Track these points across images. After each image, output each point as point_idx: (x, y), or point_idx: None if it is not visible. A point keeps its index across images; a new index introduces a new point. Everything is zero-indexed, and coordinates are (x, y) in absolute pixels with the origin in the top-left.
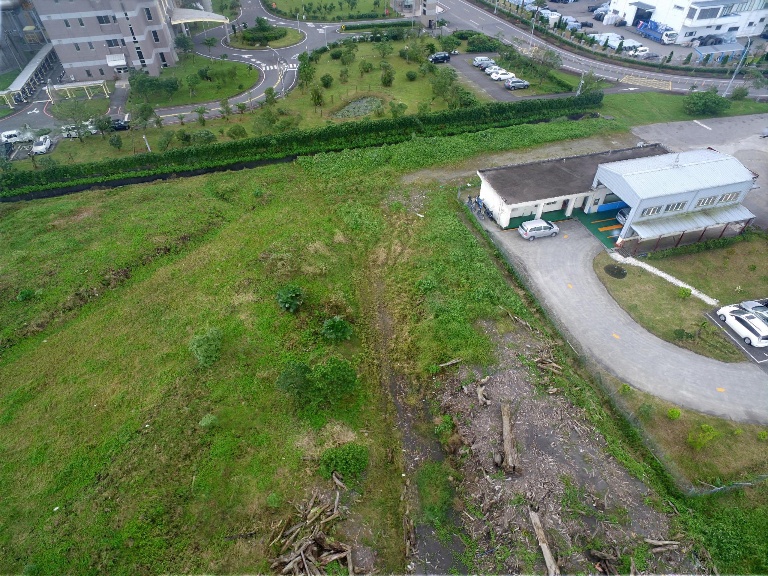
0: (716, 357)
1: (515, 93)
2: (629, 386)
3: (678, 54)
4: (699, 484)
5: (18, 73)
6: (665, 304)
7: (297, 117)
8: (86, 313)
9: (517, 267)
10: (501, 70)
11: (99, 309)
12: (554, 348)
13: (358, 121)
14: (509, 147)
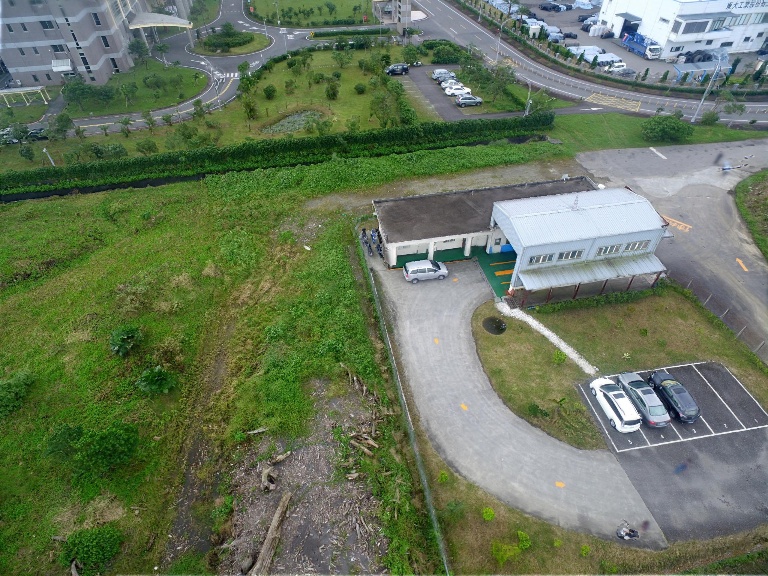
0: (570, 441)
1: (465, 110)
2: (453, 473)
3: (659, 71)
4: None
5: None
6: (535, 370)
7: (217, 132)
8: None
9: (387, 314)
10: (457, 85)
11: None
12: (384, 419)
13: (277, 139)
14: (433, 172)
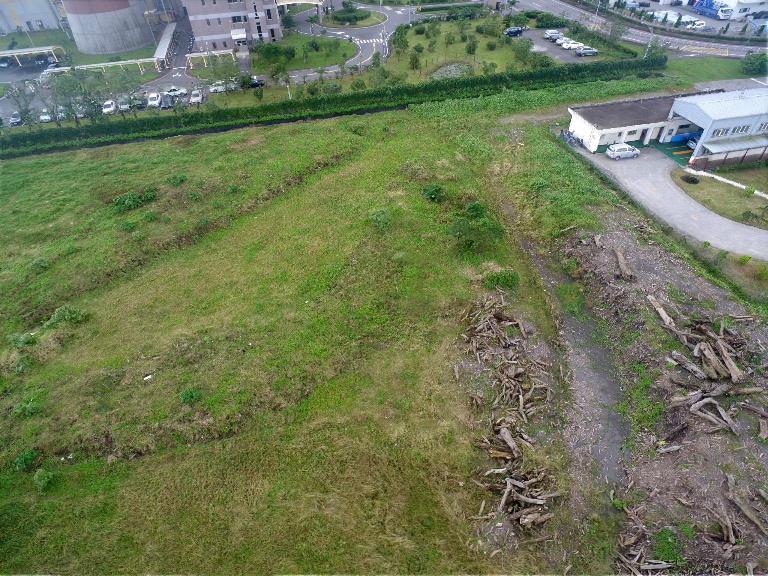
0: None
1: (586, 59)
2: None
3: (733, 27)
4: (766, 298)
5: (151, 47)
6: (733, 200)
7: (404, 75)
8: (279, 202)
9: (608, 177)
10: (571, 41)
11: (287, 200)
12: None
13: (457, 77)
14: (588, 97)
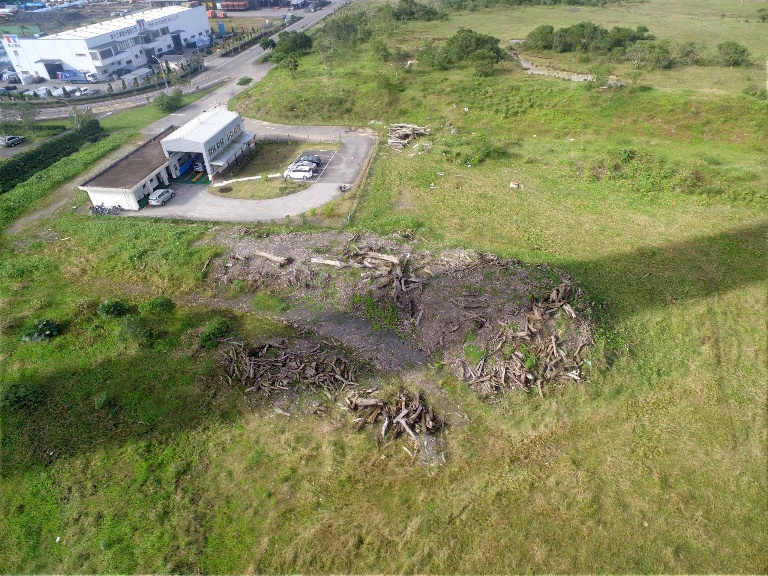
0: (302, 189)
1: (19, 147)
2: None
3: None
4: None
5: None
6: (262, 187)
7: None
8: None
9: None
10: None
11: None
12: None
13: None
14: (71, 175)
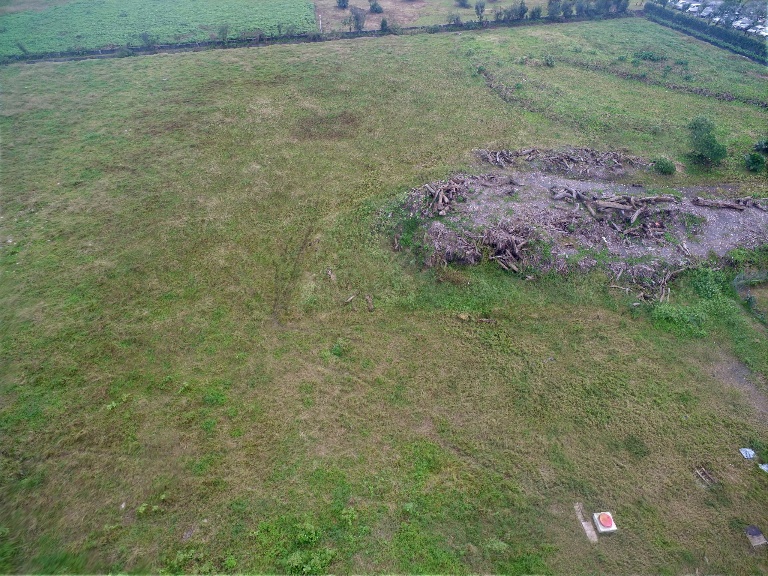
0: None
1: None
2: None
3: None
4: None
5: None
6: None
7: None
8: (692, 96)
9: None
10: None
11: None
12: None
13: None
14: None
